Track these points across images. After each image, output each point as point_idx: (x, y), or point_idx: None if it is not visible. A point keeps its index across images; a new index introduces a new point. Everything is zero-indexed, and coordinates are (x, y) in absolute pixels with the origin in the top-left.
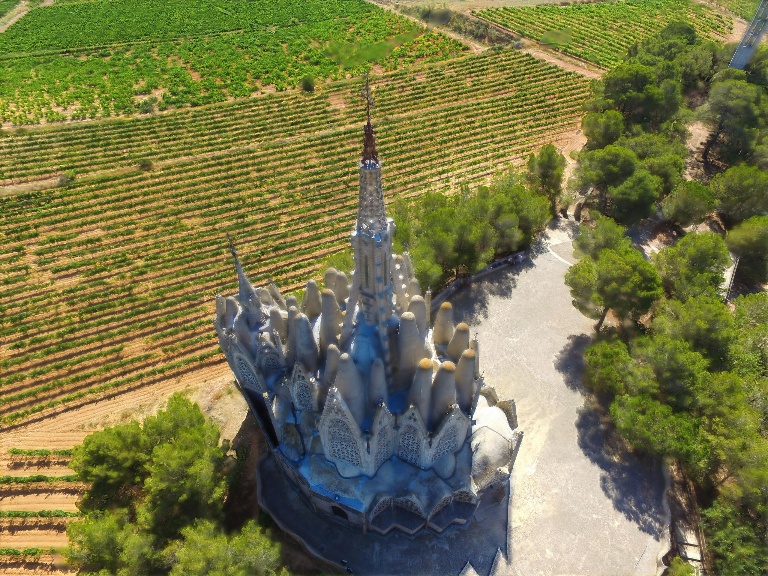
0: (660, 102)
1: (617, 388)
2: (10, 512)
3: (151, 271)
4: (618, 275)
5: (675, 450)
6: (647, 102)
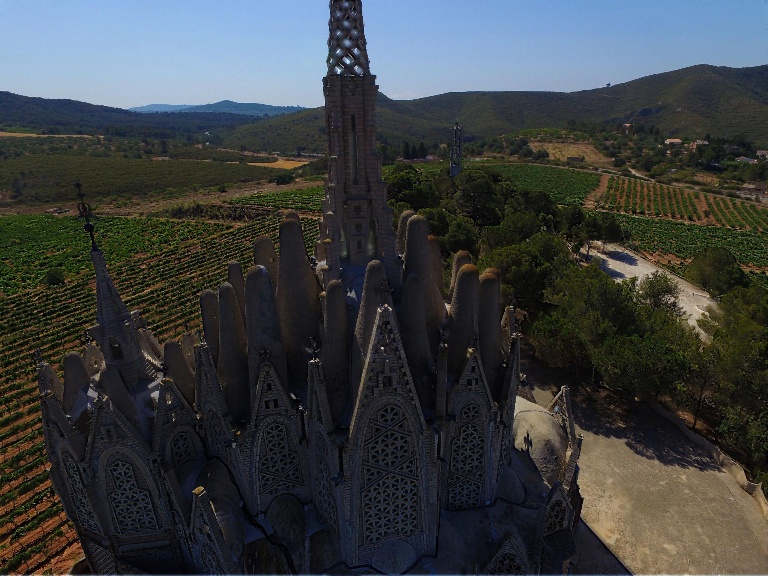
0: (427, 196)
1: (584, 343)
2: None
3: None
4: (512, 259)
5: (672, 365)
6: (419, 197)
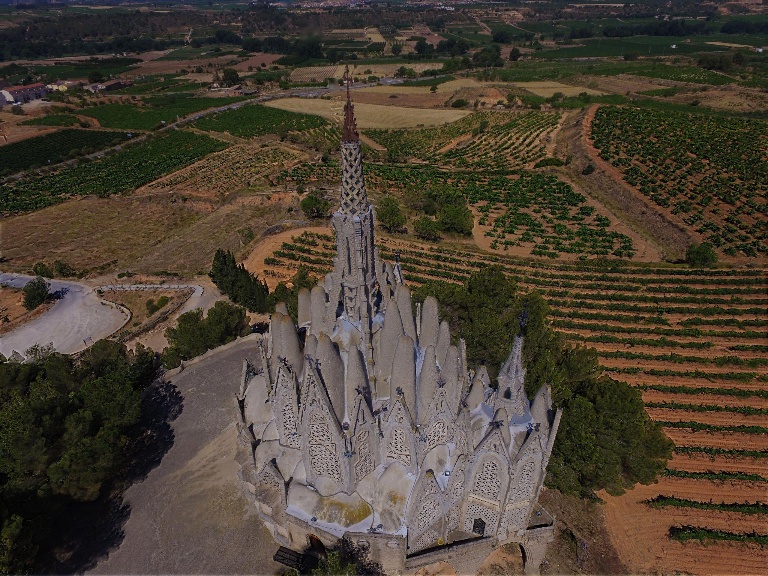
0: None
1: None
2: (724, 475)
3: None
4: None
5: None
6: None
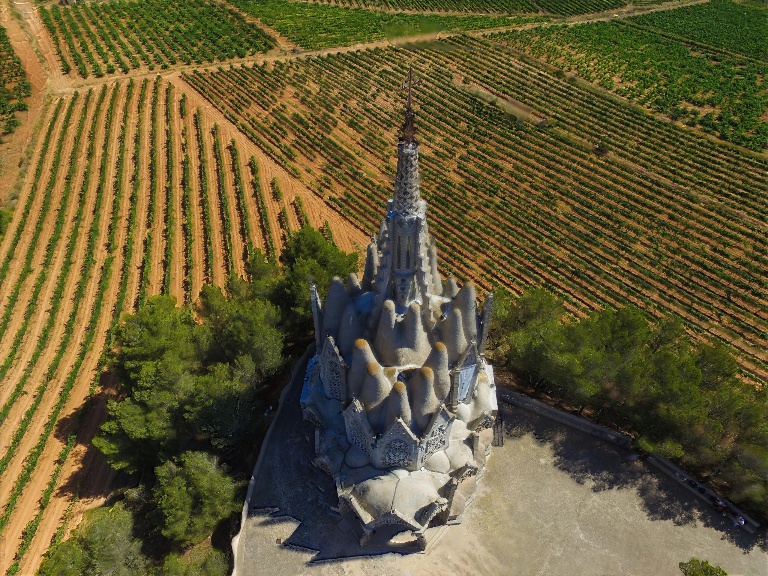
0: None
1: None
2: None
3: (492, 210)
4: None
5: None
6: None
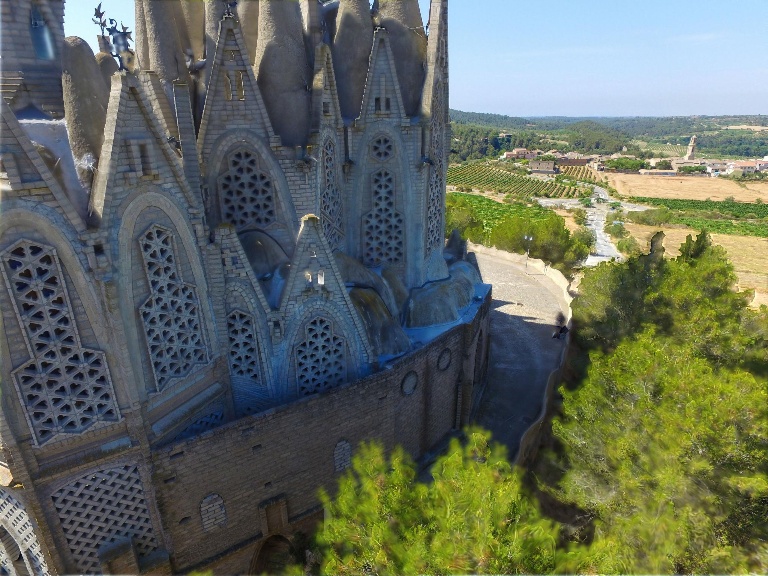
0: None
1: None
2: None
3: None
4: None
5: None
6: None
